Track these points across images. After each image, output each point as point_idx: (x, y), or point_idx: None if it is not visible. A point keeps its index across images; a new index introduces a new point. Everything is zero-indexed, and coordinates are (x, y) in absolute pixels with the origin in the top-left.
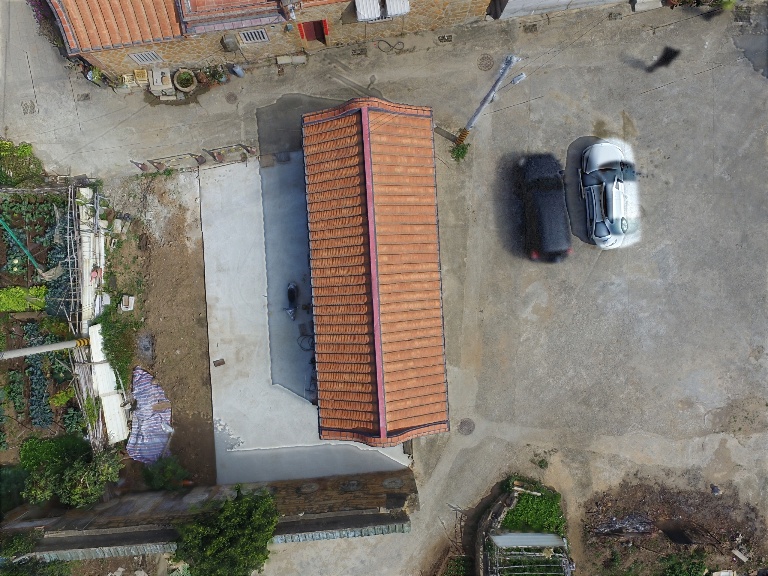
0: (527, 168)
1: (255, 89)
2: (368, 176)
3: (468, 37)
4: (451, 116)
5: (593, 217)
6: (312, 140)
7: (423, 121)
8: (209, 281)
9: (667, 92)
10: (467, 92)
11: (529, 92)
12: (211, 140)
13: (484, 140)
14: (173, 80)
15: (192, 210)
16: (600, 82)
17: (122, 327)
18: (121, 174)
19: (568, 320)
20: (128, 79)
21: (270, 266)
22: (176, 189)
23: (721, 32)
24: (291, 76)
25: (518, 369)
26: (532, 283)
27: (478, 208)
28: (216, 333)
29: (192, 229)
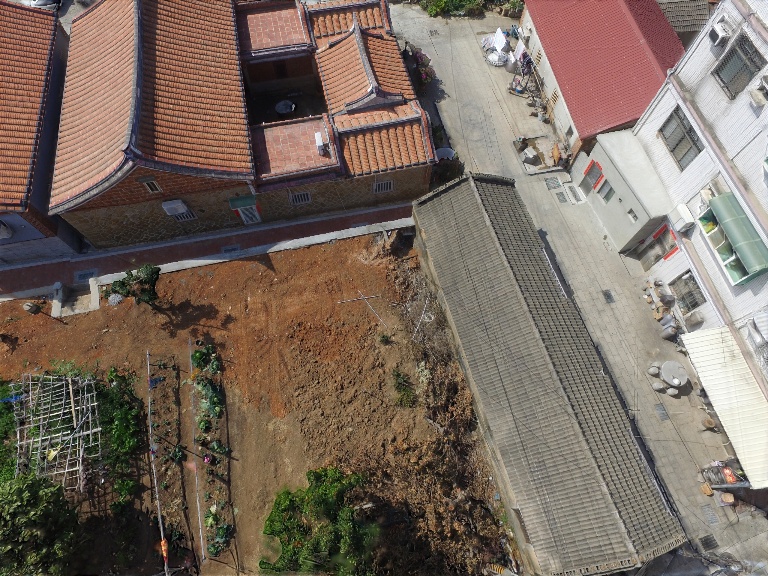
0: None
1: None
2: None
3: None
4: None
5: None
6: None
7: None
8: None
9: None
10: None
11: None
12: None
13: None
14: None
15: None
16: None
17: None
18: None
19: None
20: None
21: None
22: None
23: None
24: None
25: None
26: None
27: None
28: None
29: None
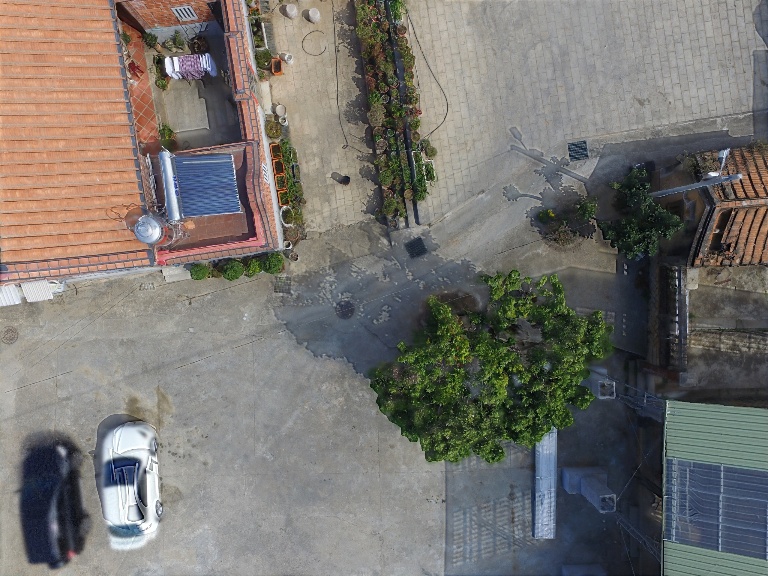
0: (54, 448)
1: None
2: None
3: None
4: None
5: (126, 500)
6: None
7: None
8: None
9: (204, 367)
10: None
11: (57, 367)
12: None
13: (7, 419)
14: None
15: None
16: (133, 355)
17: None
18: None
19: None
20: None
21: None
22: None
23: (261, 303)
24: None
25: None
26: (61, 570)
27: (1, 491)
28: None
29: None
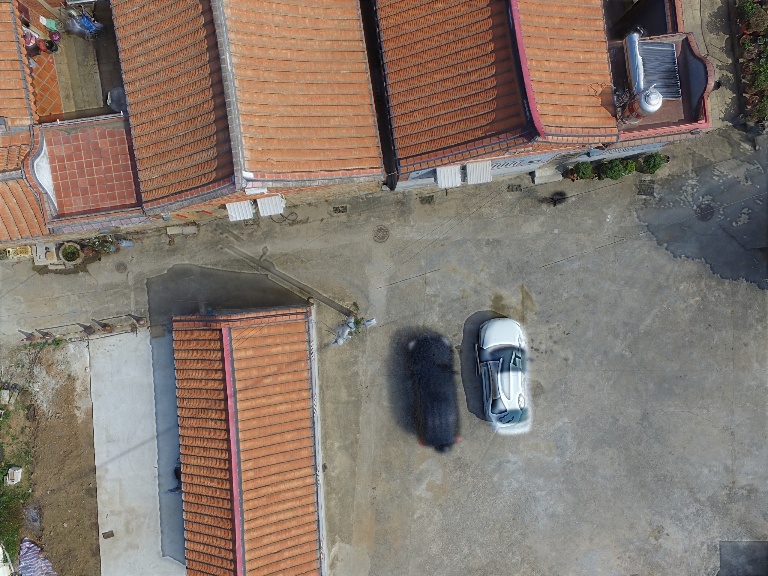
0: (422, 343)
1: (145, 258)
2: (230, 396)
3: (363, 208)
4: (345, 289)
5: (490, 393)
6: (181, 345)
7: (297, 325)
8: (98, 452)
9: (567, 266)
10: (362, 264)
11: (425, 265)
12: (100, 310)
13: (378, 314)
14: (58, 254)
15: (82, 379)
16: (499, 255)
17: (8, 500)
18: (9, 344)
19: (463, 497)
20: (13, 251)
21: (161, 437)
22: (65, 359)
23: (624, 205)
24: (182, 246)
25: (411, 546)
26: (426, 460)
27: (371, 383)
28: (105, 504)
29: (82, 398)
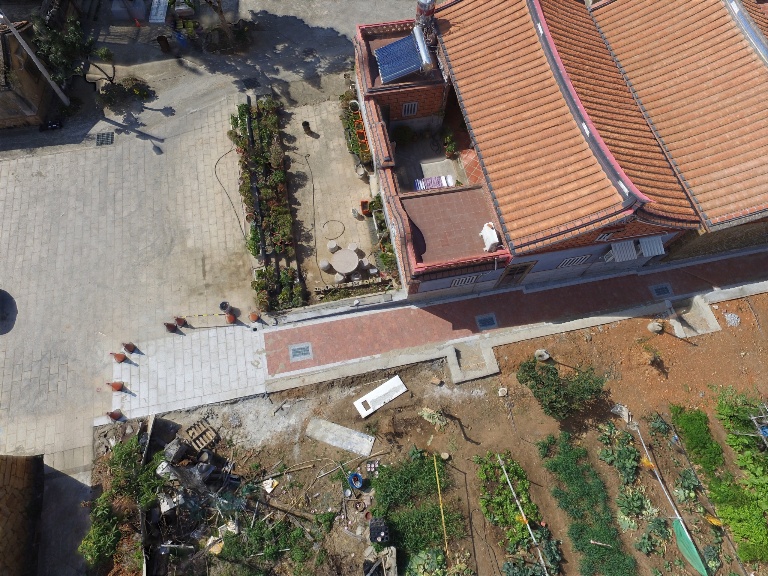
0: None
1: None
2: None
3: None
4: None
5: None
6: None
7: None
8: None
9: None
10: None
11: None
12: None
13: None
14: None
15: None
16: None
17: None
18: None
19: None
20: None
21: None
22: None
23: None
24: None
25: None
26: None
27: None
28: None
29: None
